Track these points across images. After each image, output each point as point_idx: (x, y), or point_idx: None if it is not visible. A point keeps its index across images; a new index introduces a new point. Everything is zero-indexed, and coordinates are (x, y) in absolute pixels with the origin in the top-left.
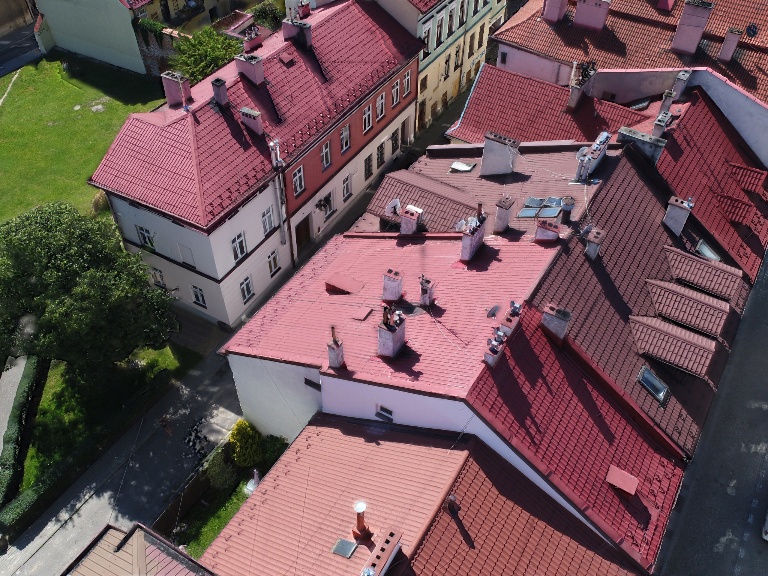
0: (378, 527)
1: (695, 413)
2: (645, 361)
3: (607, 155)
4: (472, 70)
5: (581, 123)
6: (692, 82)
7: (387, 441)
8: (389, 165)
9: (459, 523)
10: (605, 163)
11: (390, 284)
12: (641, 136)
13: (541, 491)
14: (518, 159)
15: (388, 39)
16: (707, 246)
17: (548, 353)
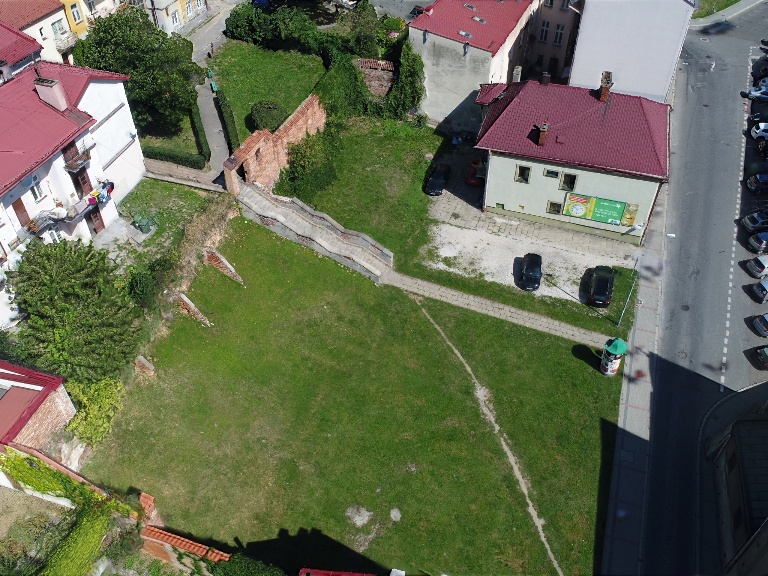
0: None
1: None
2: None
3: None
4: None
5: None
6: None
7: None
8: None
9: None
10: None
11: None
12: None
13: None
14: None
15: None
16: None
17: None
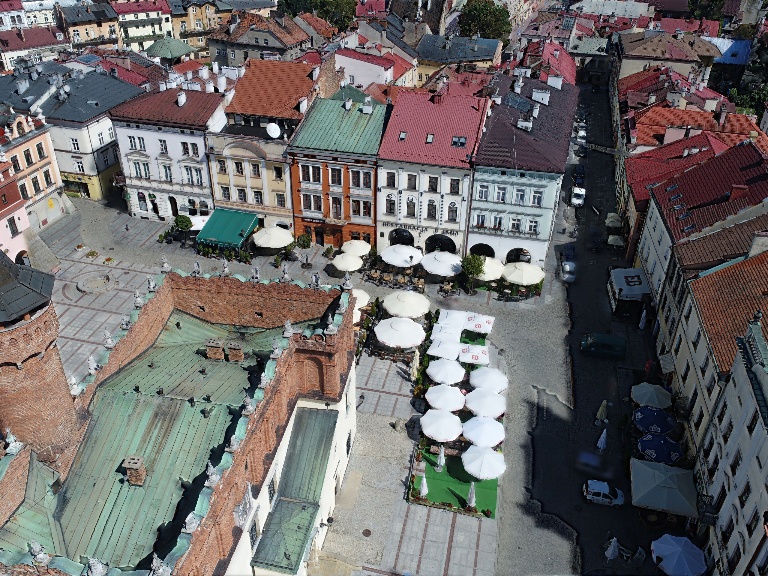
0: None
1: None
2: None
3: None
4: None
5: None
6: None
7: None
8: None
9: None
10: None
11: None
12: None
13: None
14: None
15: None
16: None
17: None
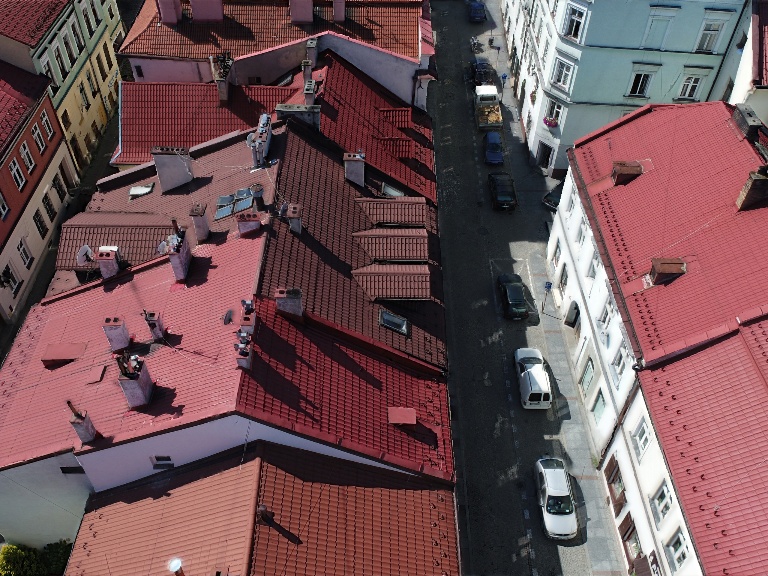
0: (202, 574)
1: (436, 332)
2: (380, 305)
3: (274, 135)
4: (112, 92)
5: (239, 113)
6: (321, 48)
7: (176, 488)
8: (63, 214)
9: (278, 528)
10: (275, 143)
11: (113, 333)
12: (297, 108)
13: (339, 460)
14: (194, 165)
15: (5, 84)
16: (390, 187)
17: (295, 334)
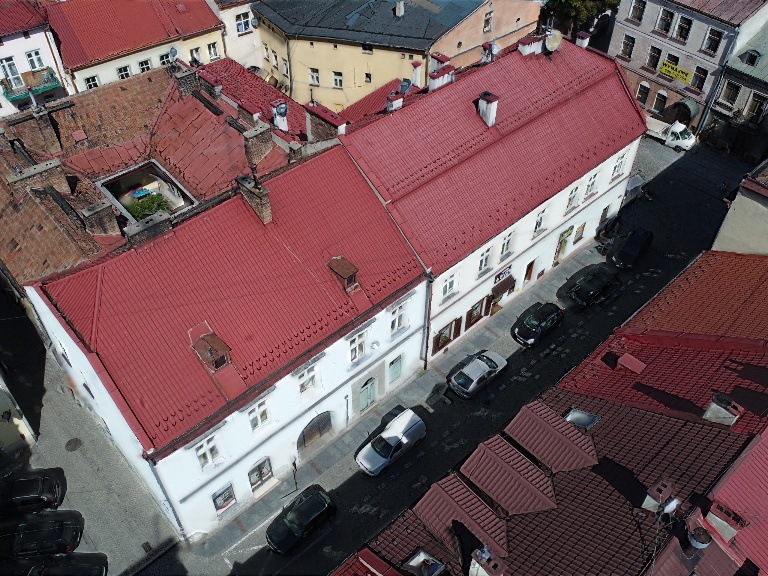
0: None
1: None
2: None
3: None
4: None
5: None
6: None
7: None
8: None
9: None
10: None
11: None
12: None
13: None
14: None
15: None
16: None
17: None
